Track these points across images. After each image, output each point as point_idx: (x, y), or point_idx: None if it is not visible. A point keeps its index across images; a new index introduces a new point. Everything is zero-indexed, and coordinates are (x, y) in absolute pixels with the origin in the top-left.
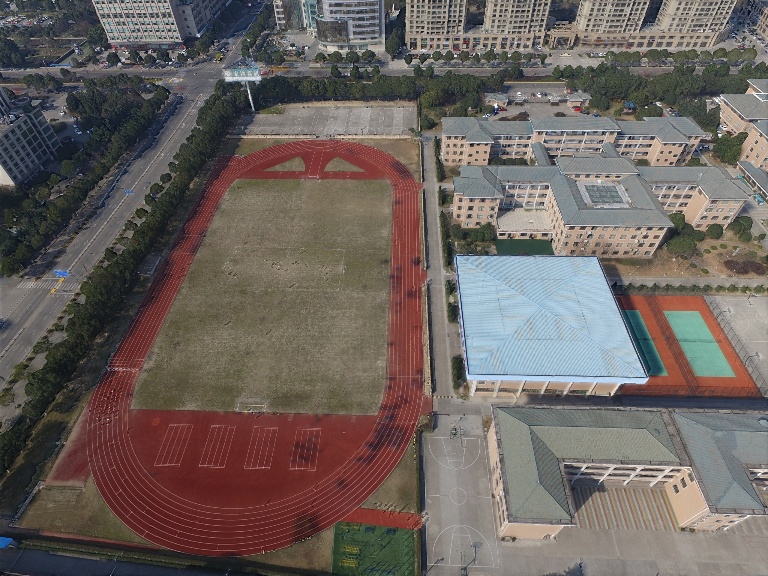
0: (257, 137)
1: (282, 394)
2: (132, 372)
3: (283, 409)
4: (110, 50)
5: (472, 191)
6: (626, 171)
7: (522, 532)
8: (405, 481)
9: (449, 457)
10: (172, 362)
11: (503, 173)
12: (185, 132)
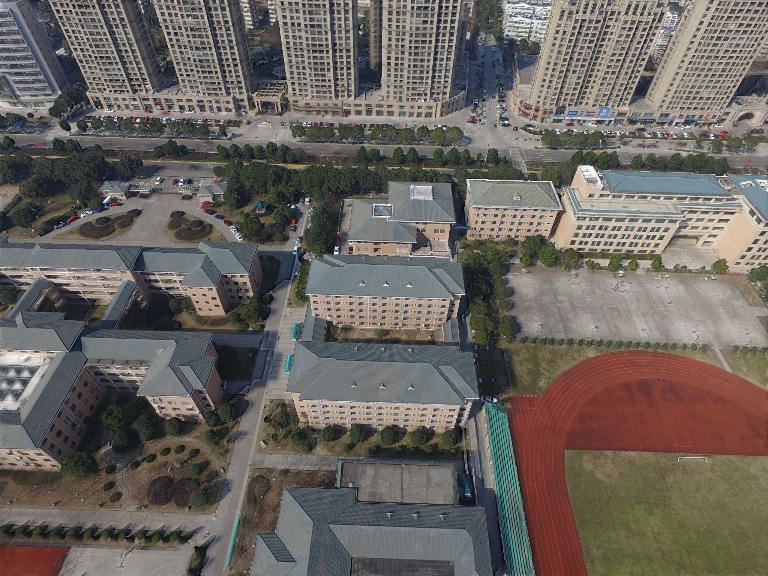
0: None
1: None
2: None
3: None
4: None
5: None
6: (50, 349)
7: None
8: None
9: None
10: None
11: None
12: None
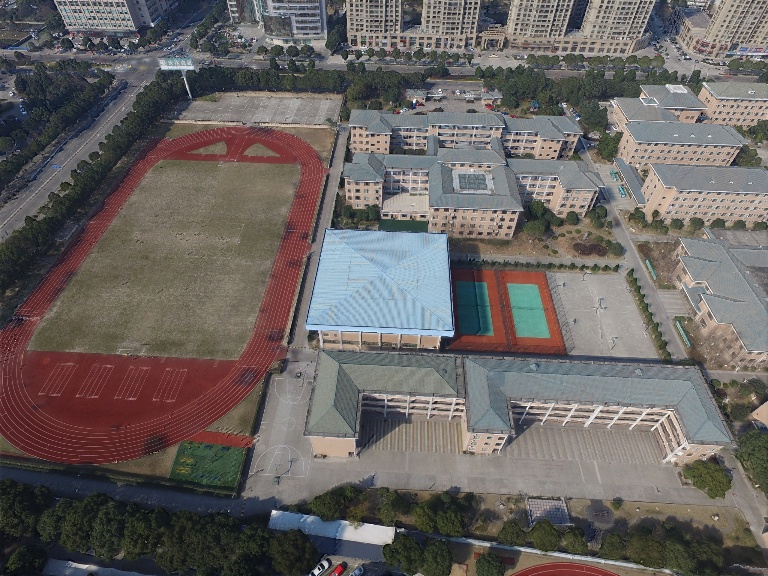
0: (189, 122)
1: (160, 342)
2: (34, 321)
3: (158, 353)
4: (68, 36)
5: (357, 175)
6: (495, 162)
7: (328, 449)
8: (247, 411)
9: (289, 394)
10: (70, 313)
11: (389, 160)
12: (123, 115)
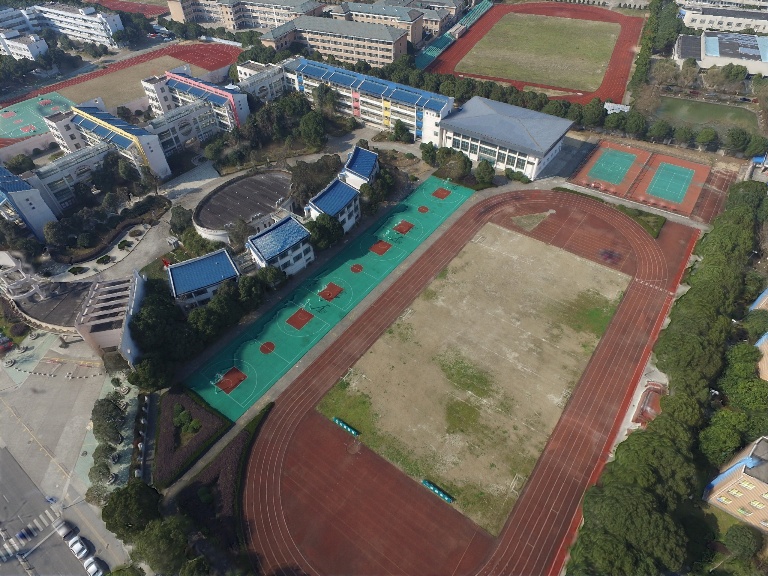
0: None
1: None
2: None
3: None
4: None
5: None
6: None
7: (176, 16)
8: None
9: None
10: None
11: None
12: None
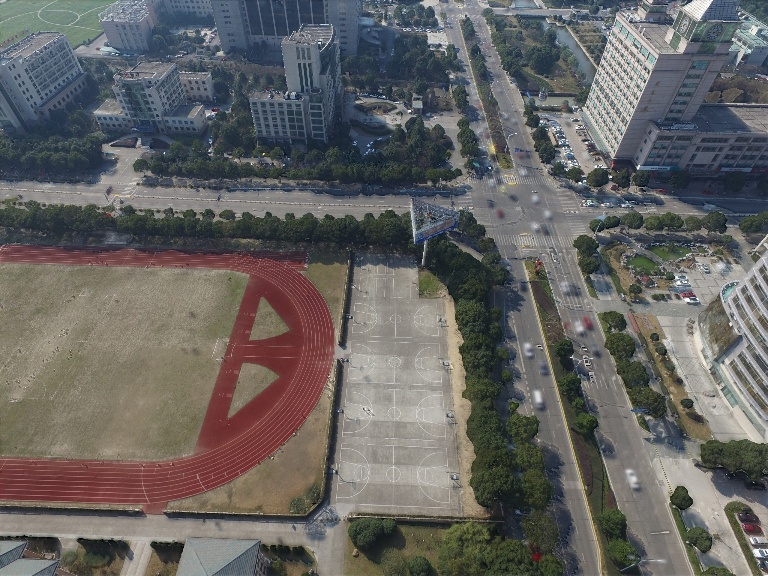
0: None
1: None
2: None
3: None
4: None
5: None
6: None
7: None
8: None
9: None
10: None
11: None
12: None
